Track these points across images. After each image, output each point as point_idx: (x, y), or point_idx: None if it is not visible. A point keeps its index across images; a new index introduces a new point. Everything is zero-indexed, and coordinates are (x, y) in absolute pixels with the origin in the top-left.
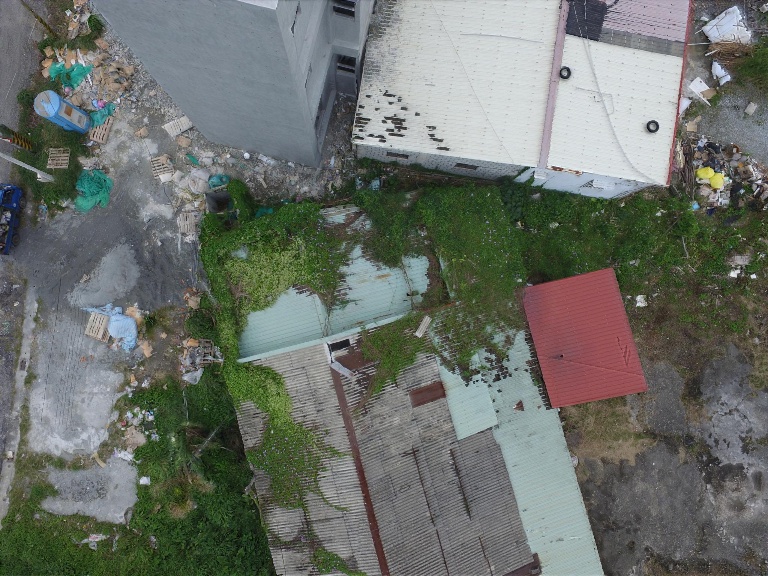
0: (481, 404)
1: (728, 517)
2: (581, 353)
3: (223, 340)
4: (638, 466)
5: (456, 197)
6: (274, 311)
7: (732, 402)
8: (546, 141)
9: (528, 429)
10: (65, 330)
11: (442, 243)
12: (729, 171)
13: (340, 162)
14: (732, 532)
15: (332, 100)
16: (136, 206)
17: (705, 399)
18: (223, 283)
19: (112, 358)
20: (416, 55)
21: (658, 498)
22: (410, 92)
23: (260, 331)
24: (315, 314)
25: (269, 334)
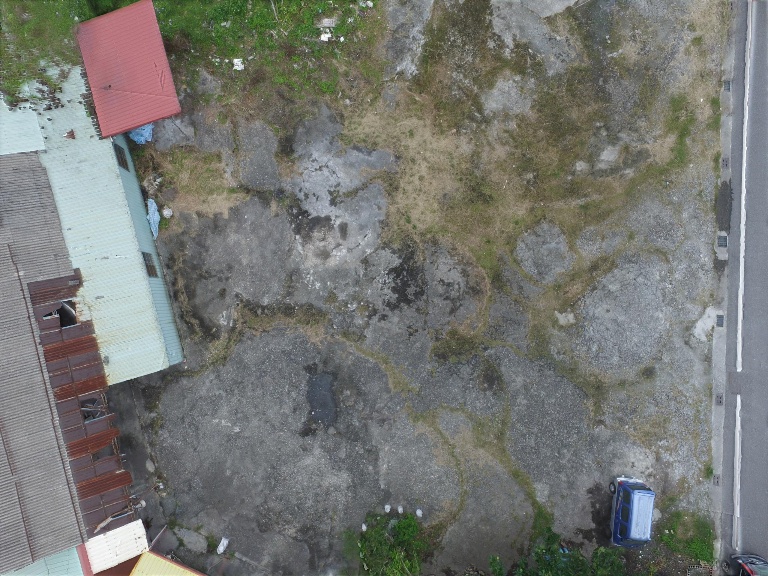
0: (27, 129)
1: (315, 265)
2: (125, 81)
3: None
4: (231, 219)
5: None
6: None
7: (322, 159)
8: None
9: (78, 156)
10: None
11: None
12: None
13: None
14: (318, 279)
15: None
16: None
17: (297, 156)
18: None
19: None
20: None
21: (249, 248)
22: None
23: None
24: None
25: None
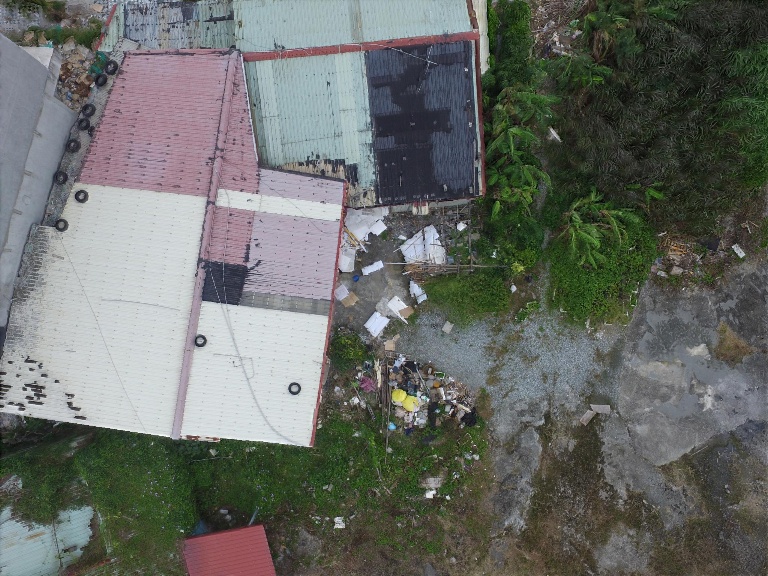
0: None
1: None
2: None
3: None
4: None
5: (114, 451)
6: None
7: None
8: (179, 412)
9: None
10: None
11: (97, 500)
12: (426, 390)
13: None
14: None
15: None
16: None
17: None
18: None
19: None
20: (58, 321)
21: None
22: (51, 358)
23: None
24: None
25: None
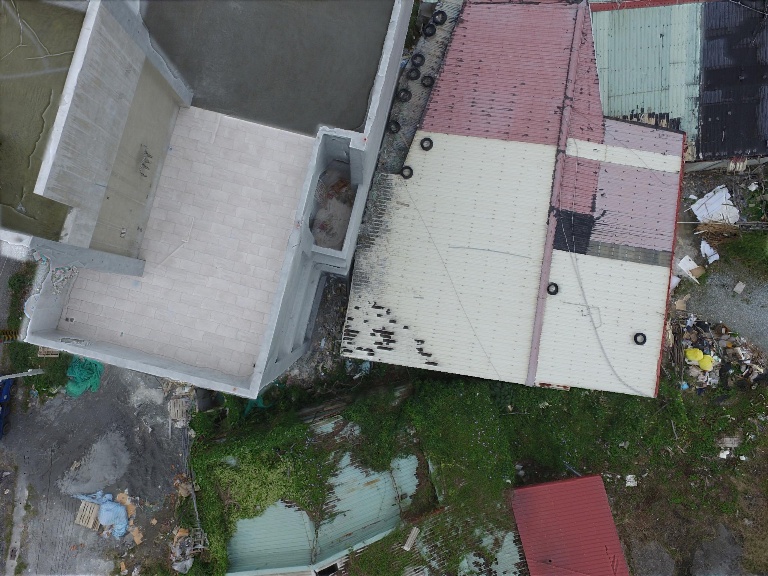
0: None
1: None
2: (569, 559)
3: (212, 553)
4: None
5: (445, 400)
6: (263, 521)
7: None
8: (534, 359)
9: None
10: (55, 518)
11: (431, 448)
12: (718, 350)
13: (330, 343)
14: None
15: (322, 285)
16: (127, 391)
17: None
18: (212, 491)
19: (102, 546)
20: (405, 267)
21: None
22: (398, 304)
23: (249, 539)
24: (303, 530)
25: (258, 543)
